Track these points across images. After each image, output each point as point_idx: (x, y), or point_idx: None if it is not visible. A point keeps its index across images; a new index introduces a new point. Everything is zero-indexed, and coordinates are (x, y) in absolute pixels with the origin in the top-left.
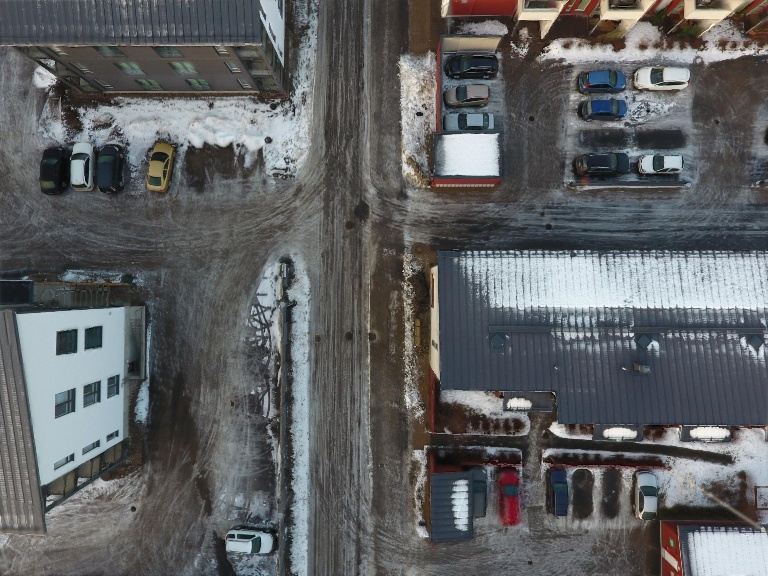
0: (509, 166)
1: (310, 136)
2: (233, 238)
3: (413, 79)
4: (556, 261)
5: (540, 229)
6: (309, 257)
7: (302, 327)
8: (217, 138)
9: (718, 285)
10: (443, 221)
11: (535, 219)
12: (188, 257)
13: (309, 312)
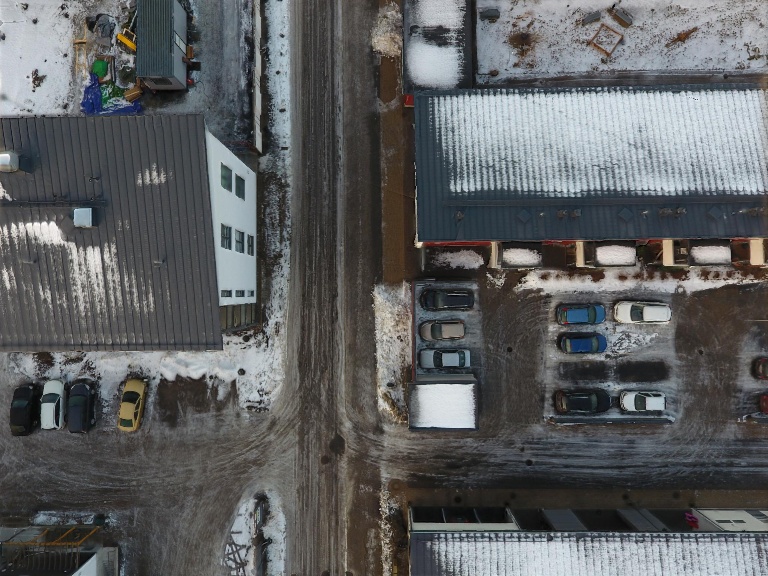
0: (487, 400)
1: (284, 368)
2: (207, 474)
3: (387, 313)
4: (532, 546)
5: (520, 465)
6: (284, 493)
7: (278, 566)
8: (189, 371)
9: (701, 574)
10: (420, 457)
11: (515, 455)
12: (161, 495)
13: (285, 550)
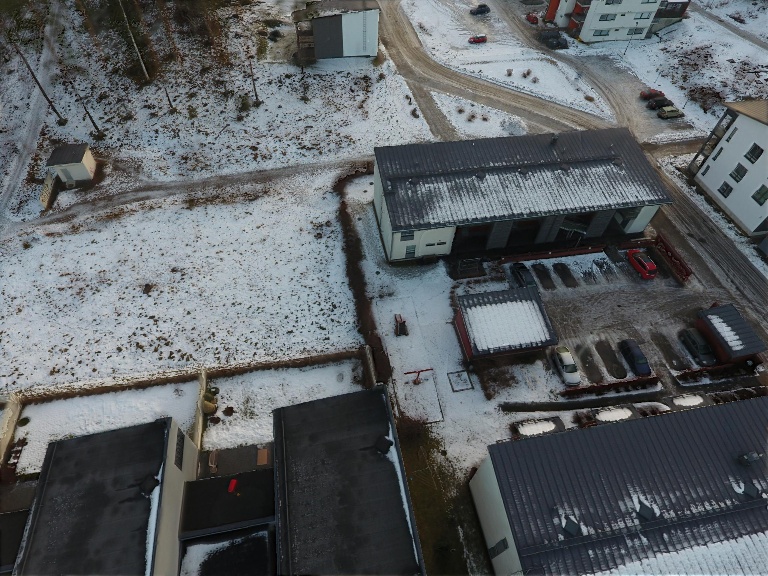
0: None
1: None
2: None
3: None
4: None
5: None
6: None
7: None
8: None
9: None
10: None
11: None
12: None
13: None
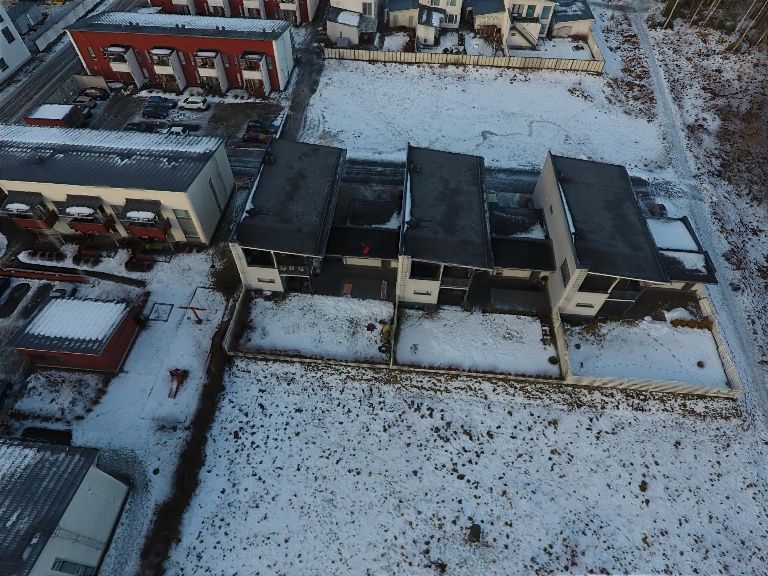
0: None
1: None
2: None
3: None
4: (39, 128)
5: None
6: None
7: None
8: None
9: None
10: None
11: None
12: None
13: None
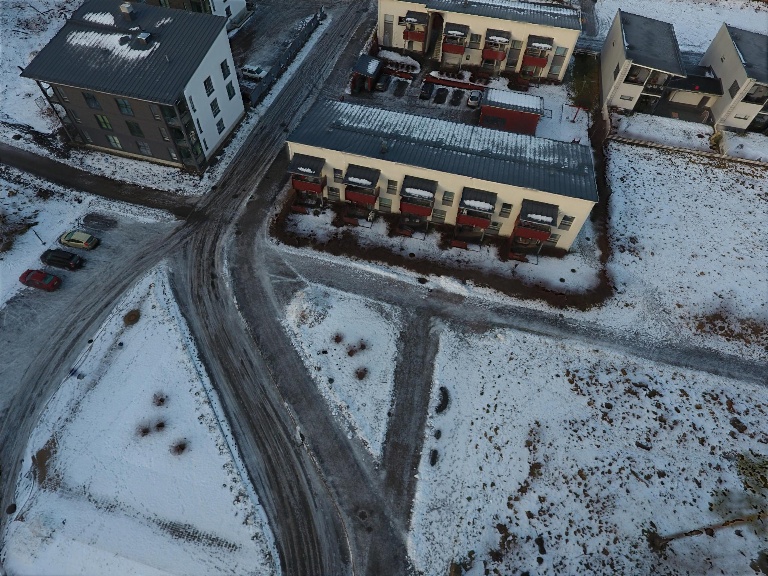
0: None
1: None
2: None
3: None
4: None
5: None
6: None
7: (321, 30)
8: None
9: None
10: None
11: None
12: None
13: (327, 27)
